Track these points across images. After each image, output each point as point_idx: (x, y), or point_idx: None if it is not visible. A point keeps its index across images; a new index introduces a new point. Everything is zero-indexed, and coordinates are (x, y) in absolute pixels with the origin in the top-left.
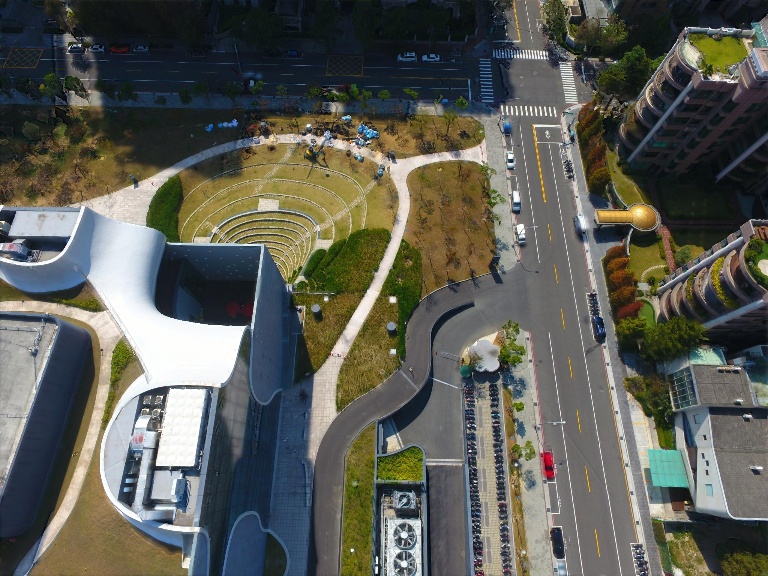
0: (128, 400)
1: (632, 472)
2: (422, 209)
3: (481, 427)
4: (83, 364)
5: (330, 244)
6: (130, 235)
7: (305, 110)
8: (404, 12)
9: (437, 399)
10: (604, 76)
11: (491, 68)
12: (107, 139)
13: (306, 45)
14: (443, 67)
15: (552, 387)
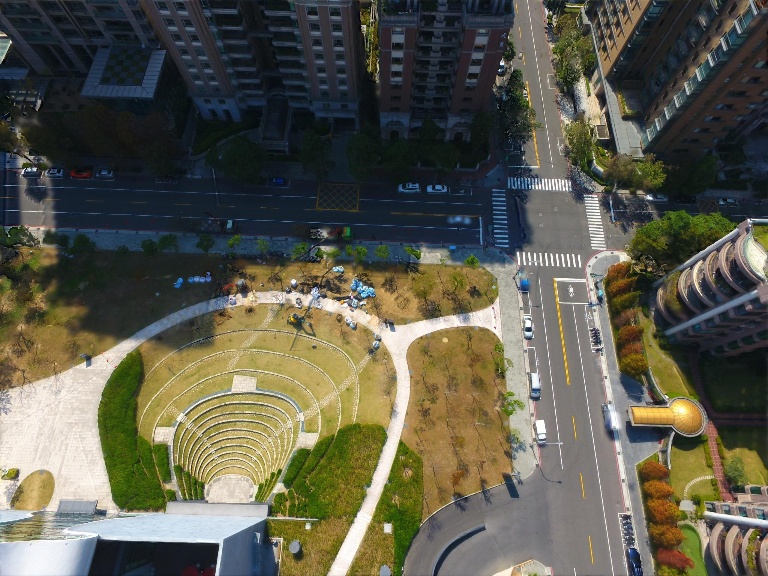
0: None
1: None
2: (424, 396)
3: None
4: None
5: (315, 440)
6: (44, 560)
7: None
8: (406, 149)
9: None
10: (640, 238)
11: (506, 202)
12: None
13: (294, 170)
14: (450, 200)
15: None
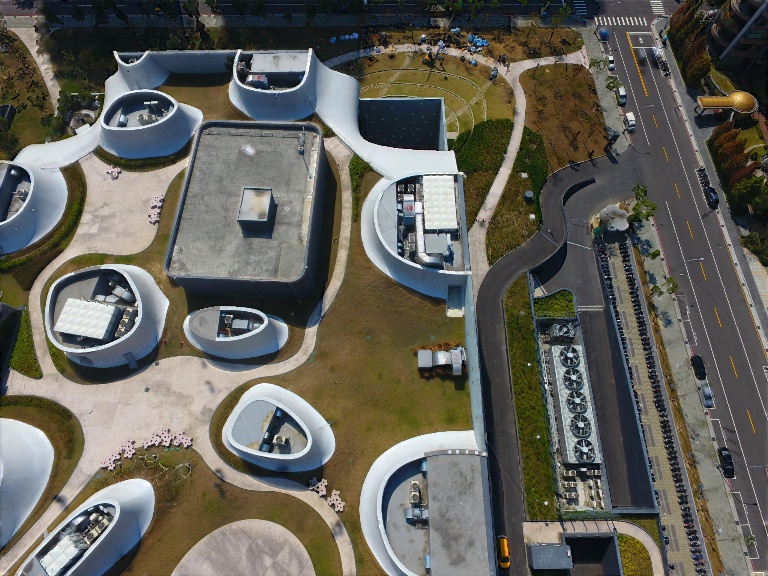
0: (388, 186)
1: (757, 311)
2: (537, 103)
3: (616, 279)
4: (325, 175)
5: (456, 135)
6: (340, 81)
7: (415, 25)
8: None
9: (573, 258)
10: None
11: None
12: (251, 44)
13: None
14: None
15: (675, 245)
